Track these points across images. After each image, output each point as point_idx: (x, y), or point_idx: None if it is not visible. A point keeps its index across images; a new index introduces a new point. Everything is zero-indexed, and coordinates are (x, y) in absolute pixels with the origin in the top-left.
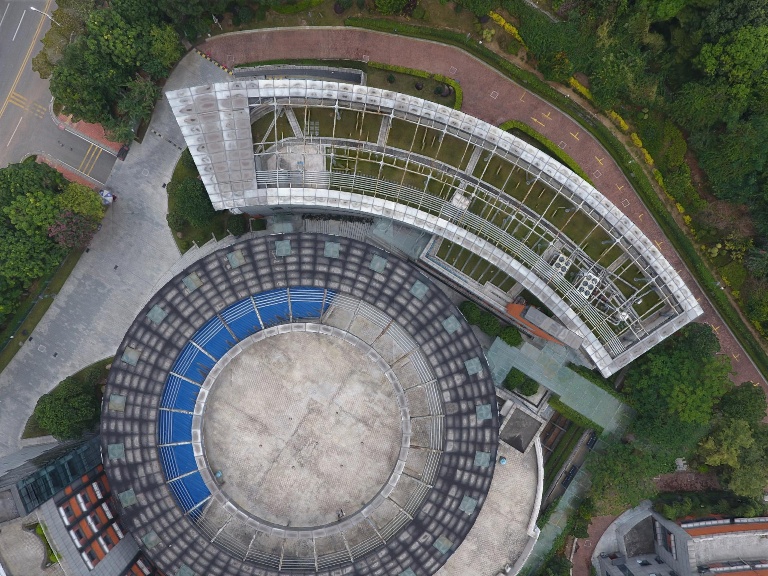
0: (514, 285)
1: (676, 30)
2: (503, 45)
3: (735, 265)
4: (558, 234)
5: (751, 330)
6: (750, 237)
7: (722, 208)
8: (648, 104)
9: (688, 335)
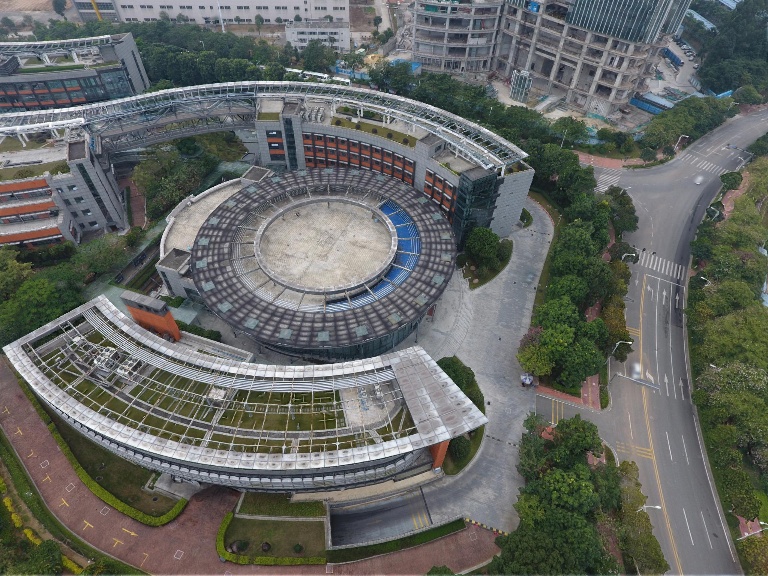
0: None
1: None
2: None
3: None
4: None
5: None
6: None
7: None
8: None
9: None
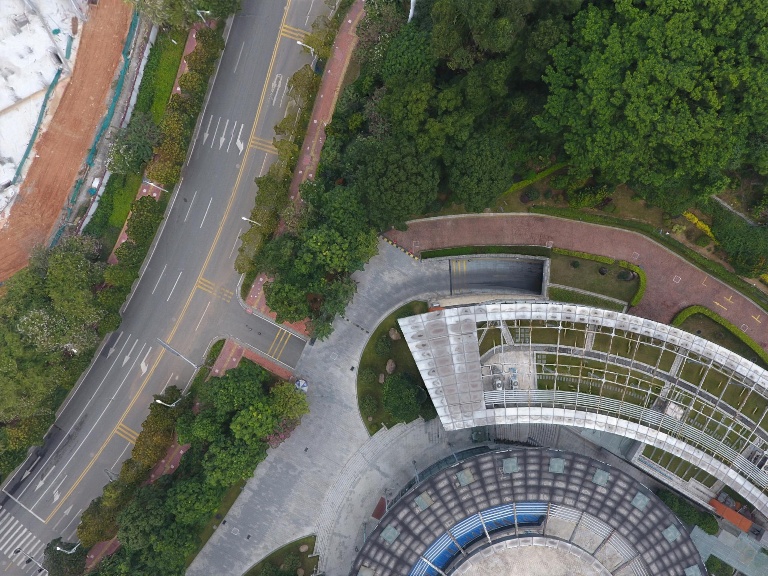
0: (717, 481)
1: None
2: (692, 239)
3: None
4: None
5: None
6: None
7: None
8: None
9: None
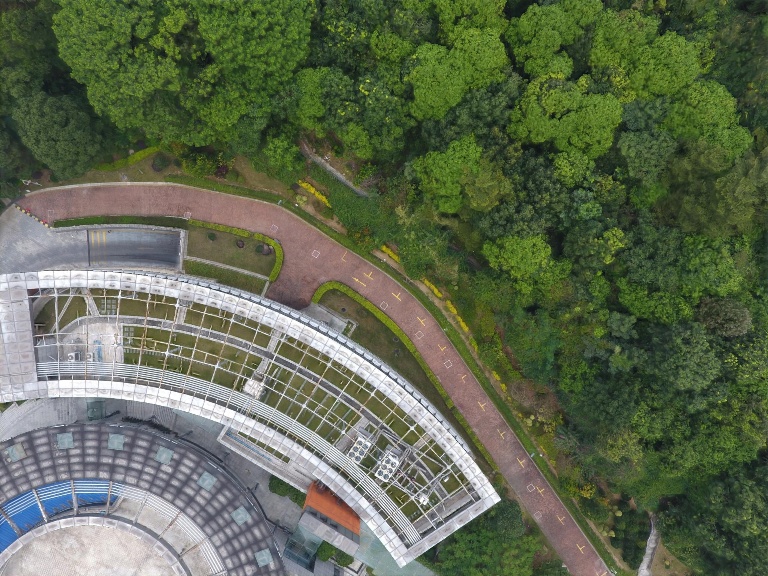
0: None
1: (460, 224)
2: (317, 210)
3: (549, 436)
4: (350, 423)
5: None
6: (559, 413)
7: (525, 388)
8: (453, 280)
9: (495, 513)
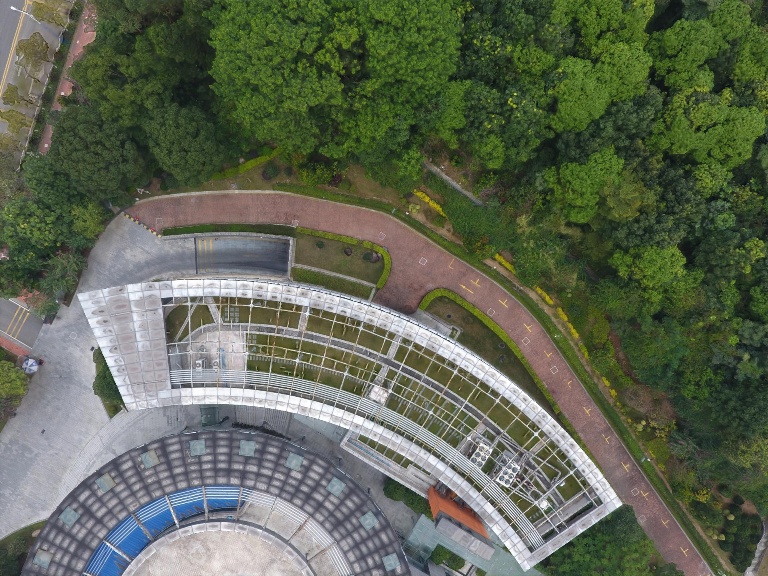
0: None
1: (589, 234)
2: (429, 219)
3: (660, 441)
4: (476, 429)
5: (678, 501)
6: (672, 418)
7: (642, 394)
8: (570, 287)
9: (611, 517)
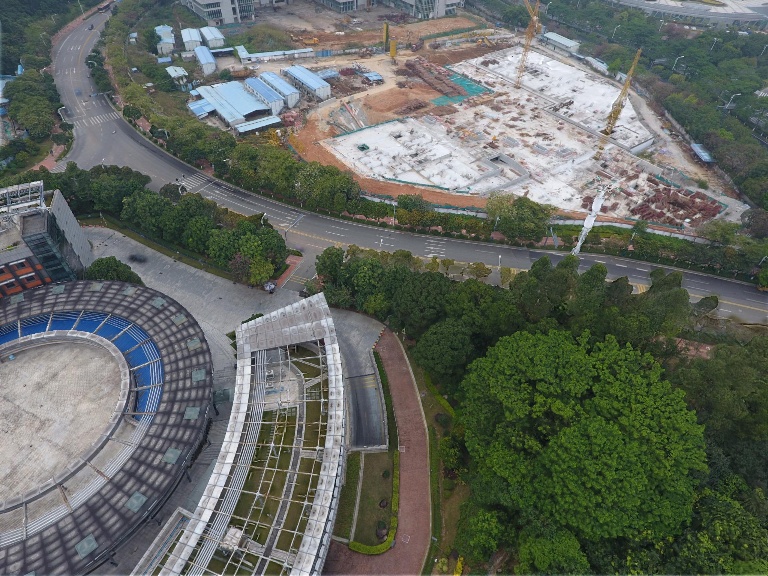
0: None
1: None
2: None
3: None
4: None
5: None
6: None
7: None
8: None
9: None
